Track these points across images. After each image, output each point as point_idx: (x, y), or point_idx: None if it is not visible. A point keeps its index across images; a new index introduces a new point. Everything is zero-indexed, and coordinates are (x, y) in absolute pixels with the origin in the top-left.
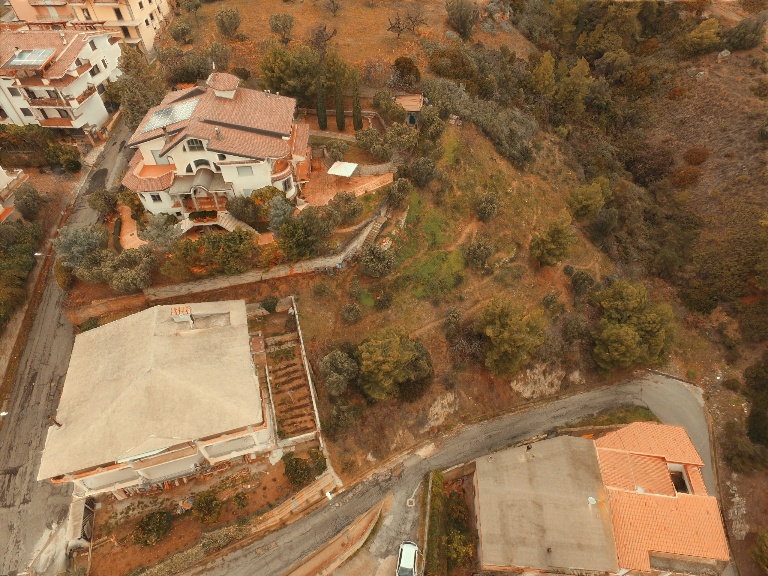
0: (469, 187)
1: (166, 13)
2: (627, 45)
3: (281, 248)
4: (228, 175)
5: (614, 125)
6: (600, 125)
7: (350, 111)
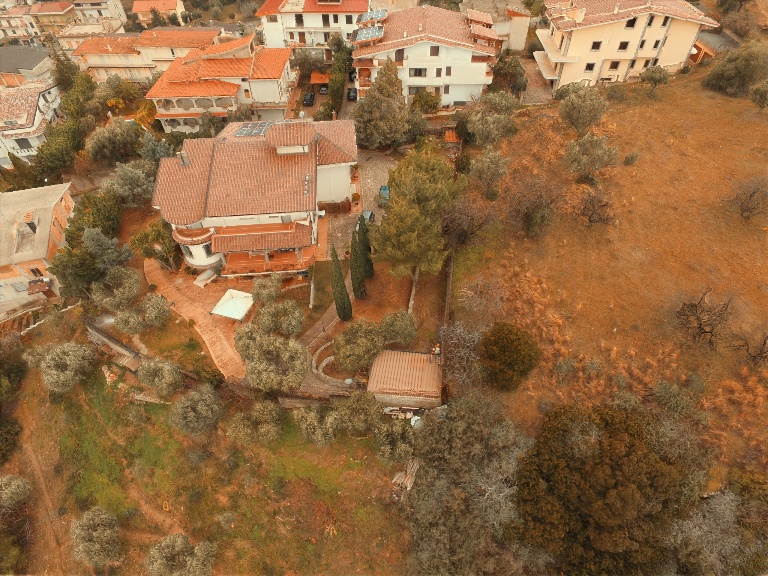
0: None
1: None
2: None
3: None
4: None
5: None
6: None
7: (412, 299)
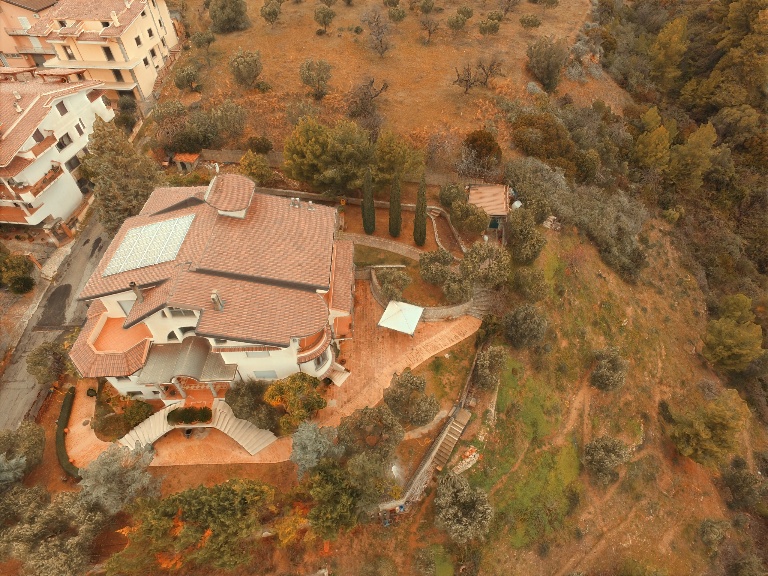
0: (577, 332)
1: (173, 45)
2: (750, 98)
3: (312, 527)
4: (230, 356)
5: (737, 206)
6: (722, 207)
7: (406, 204)
